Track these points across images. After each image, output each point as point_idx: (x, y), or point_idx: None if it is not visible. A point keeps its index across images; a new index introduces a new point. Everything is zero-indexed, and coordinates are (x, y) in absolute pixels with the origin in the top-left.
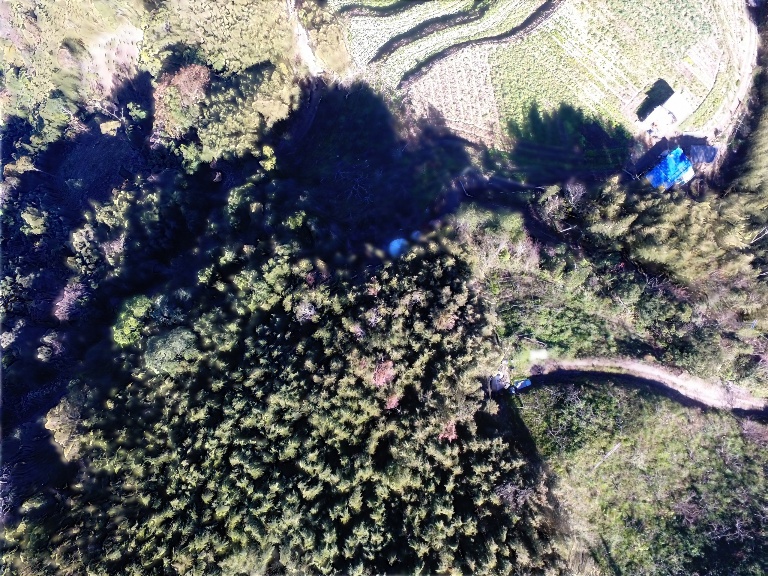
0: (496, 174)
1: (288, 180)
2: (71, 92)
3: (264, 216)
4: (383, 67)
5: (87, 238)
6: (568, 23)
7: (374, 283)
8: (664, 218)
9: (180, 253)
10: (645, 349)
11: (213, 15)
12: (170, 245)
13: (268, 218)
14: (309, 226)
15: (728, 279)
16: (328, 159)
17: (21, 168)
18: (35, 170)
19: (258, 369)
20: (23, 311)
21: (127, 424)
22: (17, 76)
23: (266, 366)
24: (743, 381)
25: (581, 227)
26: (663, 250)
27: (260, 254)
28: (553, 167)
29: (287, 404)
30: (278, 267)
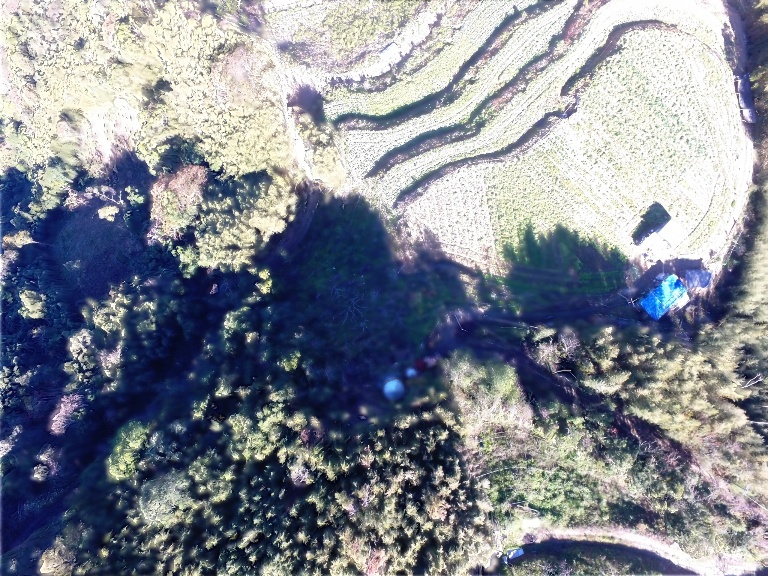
0: (491, 308)
1: (284, 305)
2: (70, 158)
3: (260, 347)
4: (379, 184)
5: (84, 344)
6: (564, 143)
7: (367, 454)
8: (657, 376)
9: (177, 360)
10: (637, 514)
11: (210, 120)
12: (167, 354)
13: (263, 353)
14: (304, 369)
15: (721, 443)
16: (324, 271)
17: (19, 243)
18: (34, 242)
19: (252, 531)
20: (20, 406)
21: (122, 575)
22: (16, 132)
23: (260, 526)
24: (735, 551)
25: (575, 373)
26: (656, 413)
27: (255, 394)
28: (548, 291)
29: (280, 575)
30: (273, 417)
